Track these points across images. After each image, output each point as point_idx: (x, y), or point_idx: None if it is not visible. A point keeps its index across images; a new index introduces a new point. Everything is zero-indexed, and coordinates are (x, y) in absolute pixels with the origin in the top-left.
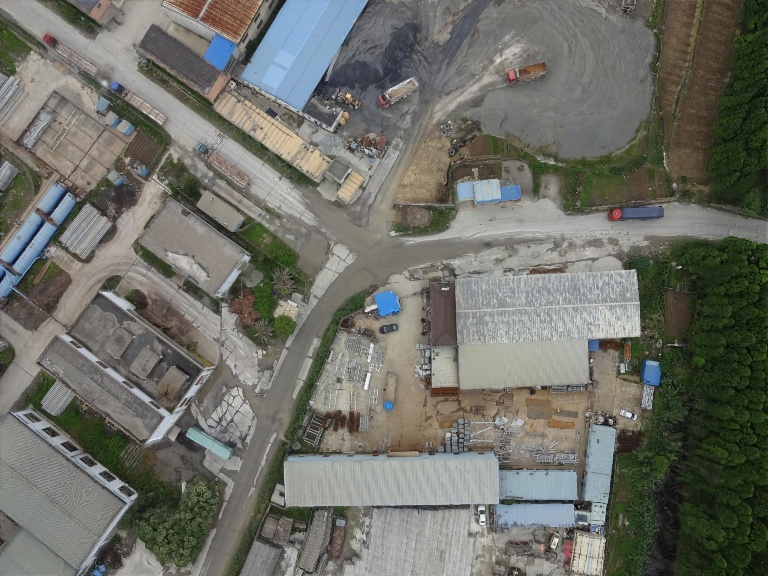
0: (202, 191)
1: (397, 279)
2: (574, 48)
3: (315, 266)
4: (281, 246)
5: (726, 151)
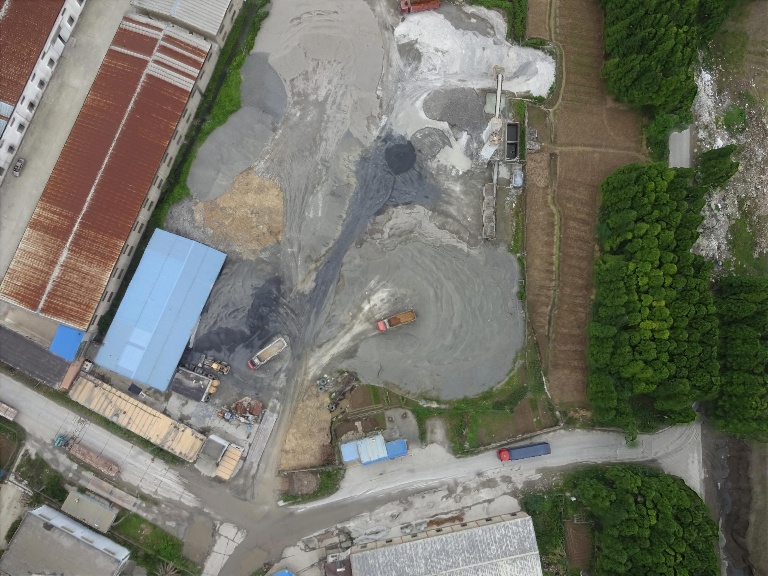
0: (67, 487)
1: (291, 552)
2: (440, 292)
3: (202, 551)
4: (162, 536)
5: (600, 383)
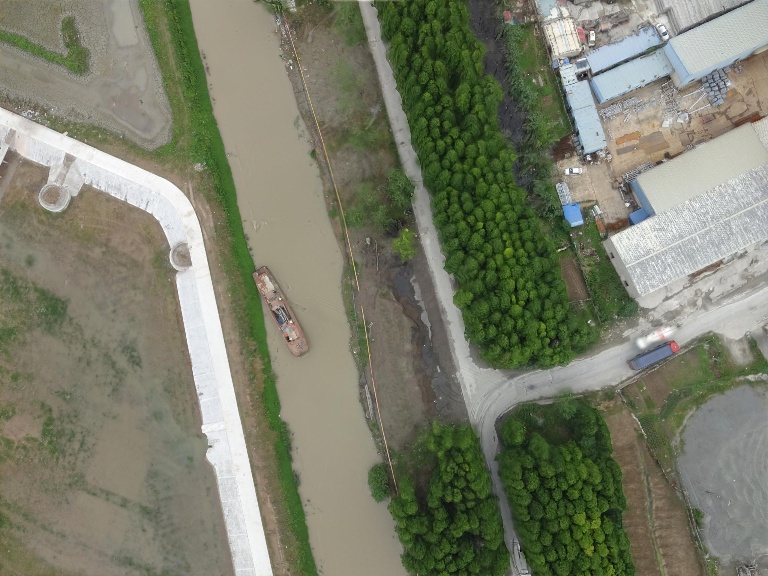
0: None
1: None
2: None
3: None
4: None
5: None
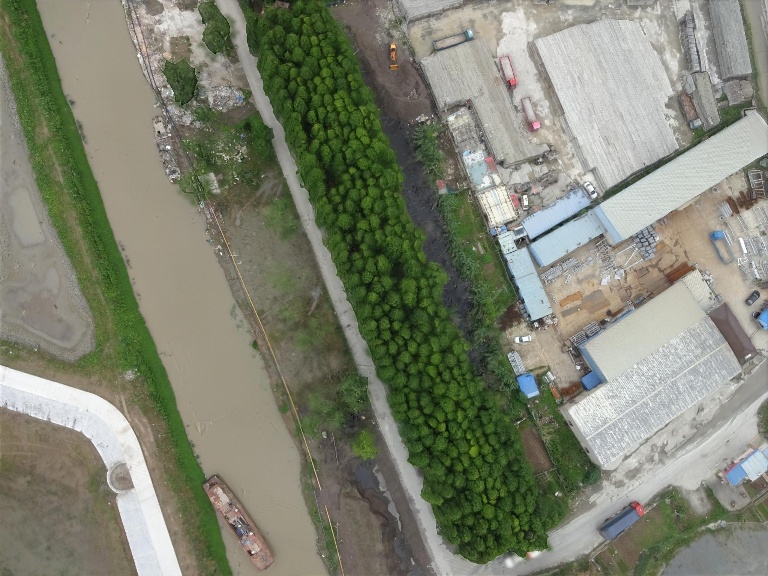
0: None
1: None
2: None
3: None
4: None
5: None
